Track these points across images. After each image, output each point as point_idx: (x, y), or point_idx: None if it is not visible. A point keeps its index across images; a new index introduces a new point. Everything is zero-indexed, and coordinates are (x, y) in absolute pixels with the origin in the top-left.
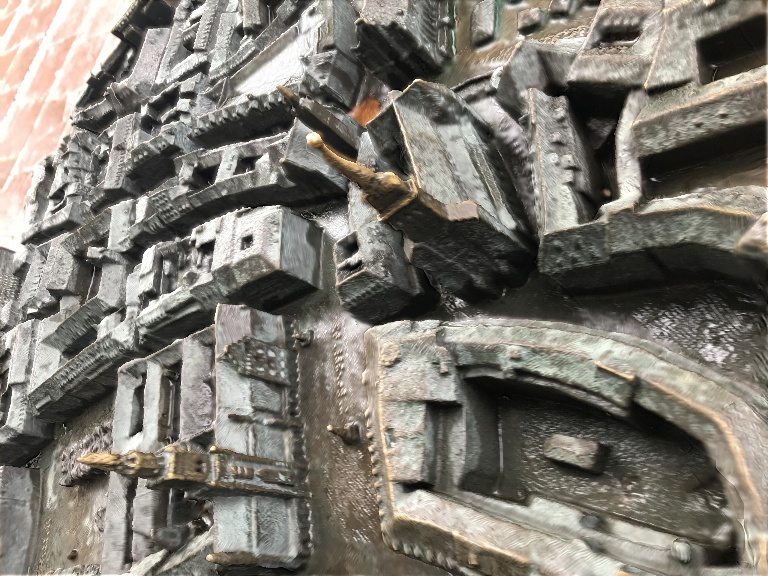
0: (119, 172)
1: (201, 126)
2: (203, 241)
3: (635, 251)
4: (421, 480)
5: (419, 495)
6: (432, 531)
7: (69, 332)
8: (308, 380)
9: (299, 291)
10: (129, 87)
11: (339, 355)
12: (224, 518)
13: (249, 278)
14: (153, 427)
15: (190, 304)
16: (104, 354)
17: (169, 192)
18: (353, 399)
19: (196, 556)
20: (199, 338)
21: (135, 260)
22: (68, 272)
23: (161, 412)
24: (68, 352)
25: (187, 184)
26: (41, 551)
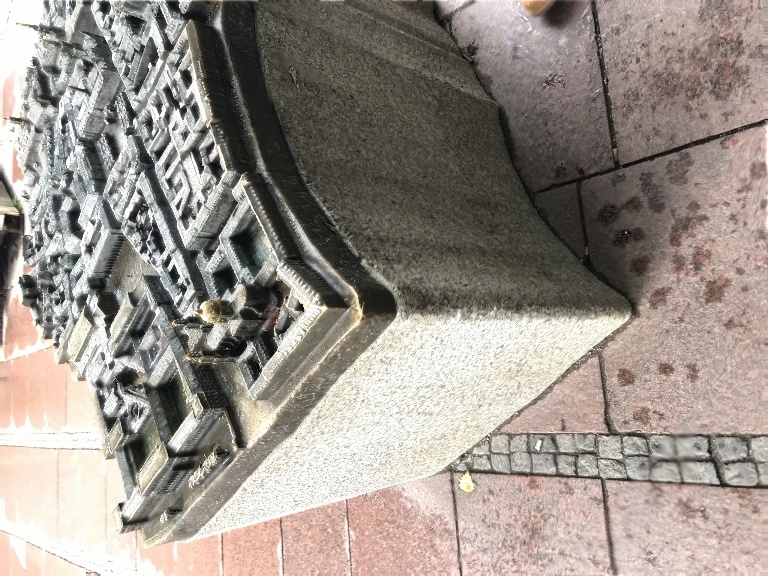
0: None
1: (50, 178)
2: None
3: (62, 2)
4: None
5: None
6: None
7: None
8: None
9: None
10: (40, 261)
11: None
12: None
13: None
14: None
15: None
16: None
17: None
18: None
19: None
20: None
21: None
22: None
23: None
24: None
25: None
26: None
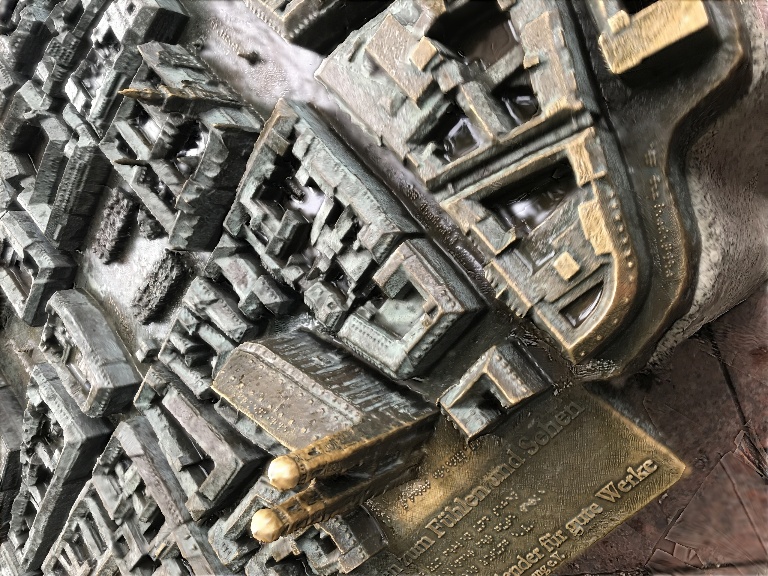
0: (5, 75)
1: None
2: (103, 34)
3: None
4: (286, 0)
5: (288, 5)
6: (300, 8)
7: (44, 184)
8: (214, 62)
9: (179, 25)
10: None
11: (223, 33)
12: (211, 120)
13: (145, 27)
14: (143, 147)
15: (118, 79)
16: (81, 162)
17: (57, 39)
18: (243, 44)
19: (208, 148)
20: (138, 79)
21: (59, 113)
22: (13, 163)
23: (142, 140)
24: (51, 202)
25: (65, 29)
26: (117, 316)
